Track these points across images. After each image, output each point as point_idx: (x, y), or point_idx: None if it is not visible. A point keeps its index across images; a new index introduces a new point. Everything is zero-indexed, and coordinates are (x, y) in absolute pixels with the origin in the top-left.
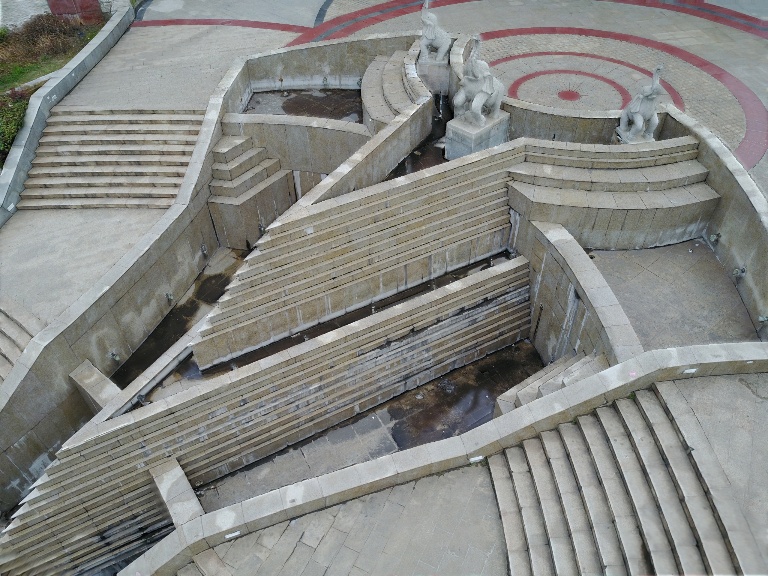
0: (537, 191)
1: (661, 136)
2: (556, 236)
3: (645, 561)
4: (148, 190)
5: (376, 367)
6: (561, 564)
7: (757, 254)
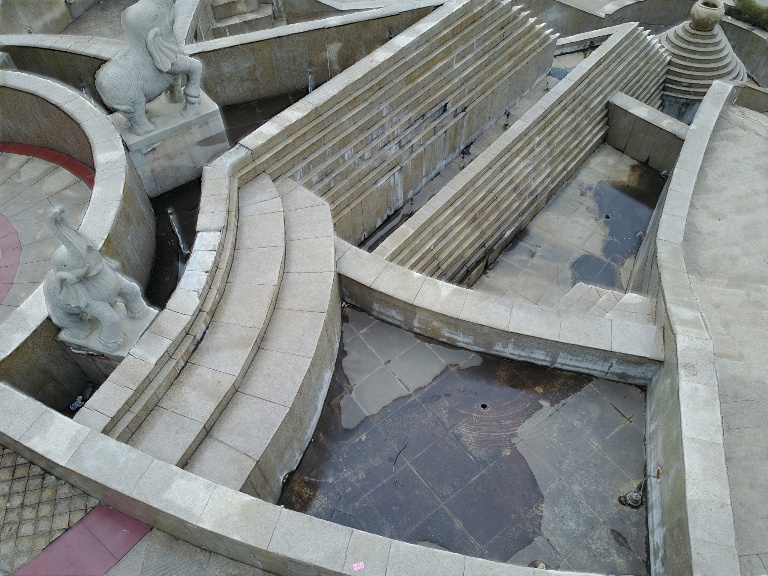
0: None
1: None
2: None
3: None
4: (755, 297)
5: None
6: None
7: (20, 2)
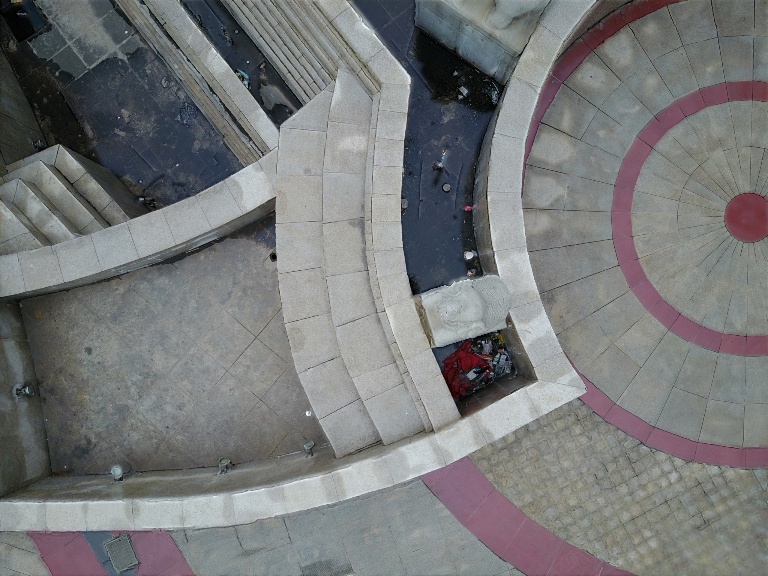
0: (311, 135)
1: (520, 378)
2: (249, 183)
3: None
4: None
5: (132, 1)
6: None
7: None
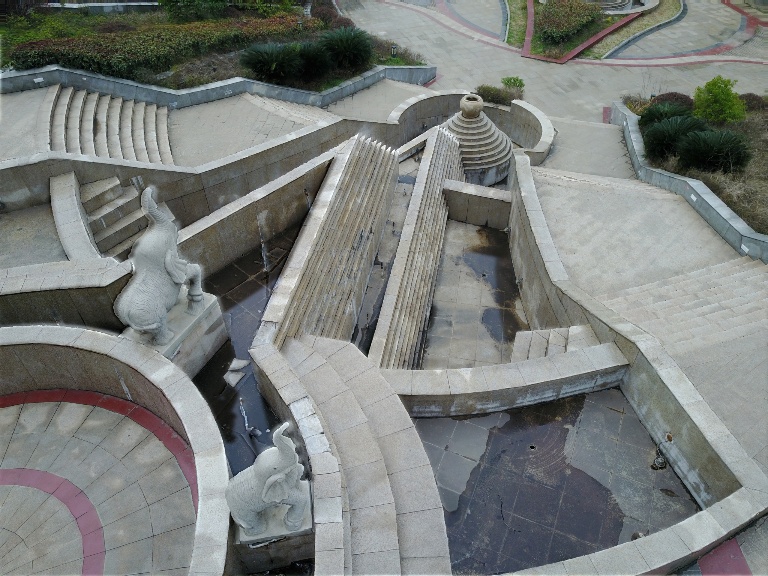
0: None
1: None
2: None
3: (97, 133)
4: (631, 299)
5: None
6: (142, 142)
7: None
